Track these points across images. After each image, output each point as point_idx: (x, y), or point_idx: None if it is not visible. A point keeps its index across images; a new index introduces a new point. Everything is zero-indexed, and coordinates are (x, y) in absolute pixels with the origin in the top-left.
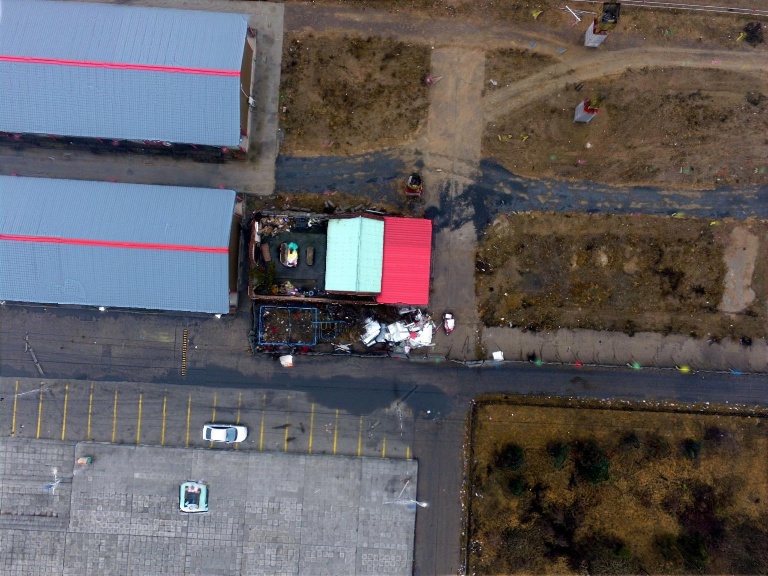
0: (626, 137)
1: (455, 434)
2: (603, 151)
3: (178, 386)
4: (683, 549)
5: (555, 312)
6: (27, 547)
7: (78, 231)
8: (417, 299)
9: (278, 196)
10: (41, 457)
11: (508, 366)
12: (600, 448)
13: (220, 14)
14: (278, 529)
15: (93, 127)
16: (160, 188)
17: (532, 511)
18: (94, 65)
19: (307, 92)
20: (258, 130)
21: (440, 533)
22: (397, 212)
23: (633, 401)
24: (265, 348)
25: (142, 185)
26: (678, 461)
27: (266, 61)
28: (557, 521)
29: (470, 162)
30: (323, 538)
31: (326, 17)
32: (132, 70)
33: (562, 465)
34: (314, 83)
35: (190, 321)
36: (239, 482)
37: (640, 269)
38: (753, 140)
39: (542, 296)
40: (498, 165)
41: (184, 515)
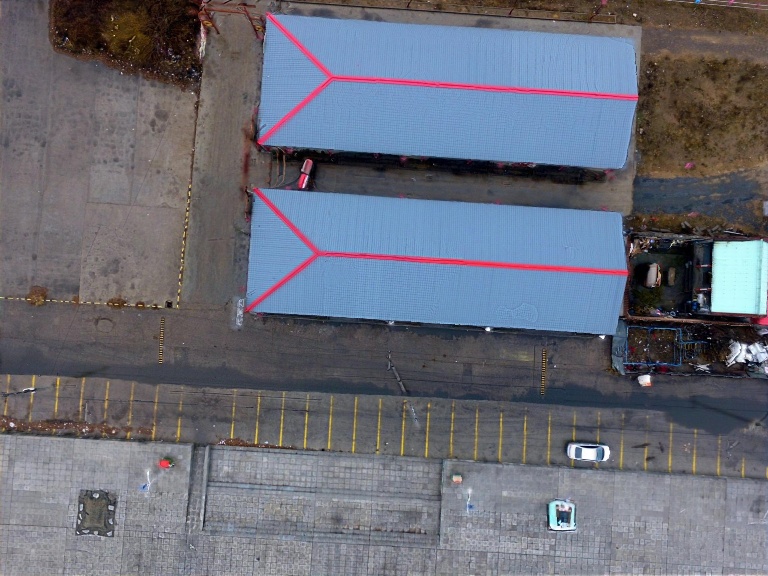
0: None
1: None
2: None
3: (537, 405)
4: None
5: None
6: (399, 564)
7: (478, 253)
8: None
9: (635, 217)
10: (407, 474)
11: None
12: None
13: None
14: (645, 548)
15: (482, 150)
16: (547, 210)
17: None
18: (498, 90)
19: (663, 114)
20: None
21: None
22: (754, 233)
23: None
24: (626, 368)
25: (530, 207)
26: None
27: None
28: None
29: None
30: (689, 558)
31: (682, 40)
32: (536, 95)
33: None
34: (670, 105)
35: (549, 340)
36: (605, 501)
37: None
38: None
39: None
40: None
41: (552, 533)
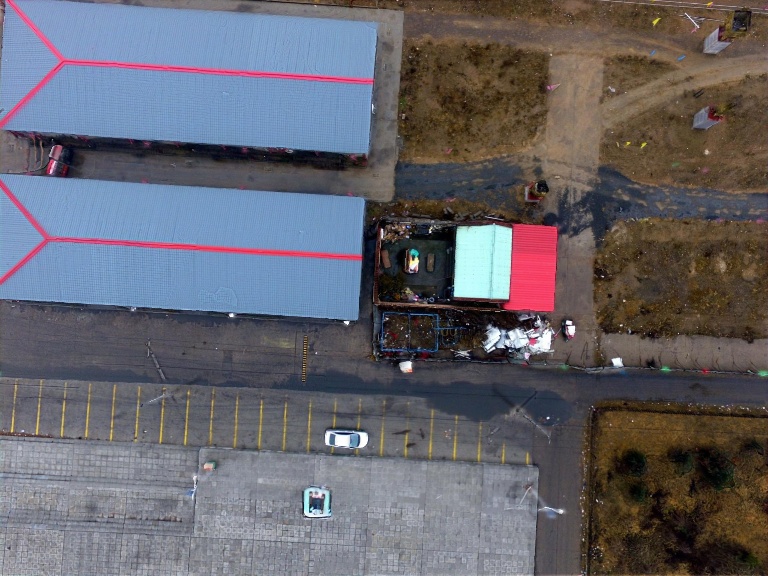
0: (744, 144)
1: (574, 440)
2: (721, 158)
3: (298, 392)
4: None
5: (674, 319)
6: (152, 552)
7: (212, 238)
8: (543, 306)
9: (397, 203)
10: (164, 462)
11: (627, 372)
12: None
13: (348, 22)
14: (400, 535)
15: (224, 135)
16: (290, 195)
17: (653, 517)
18: (230, 73)
19: (426, 99)
20: (378, 137)
21: (560, 539)
22: (516, 219)
23: (752, 408)
24: (386, 354)
25: (272, 192)
26: None
27: (385, 68)
28: (678, 527)
29: (588, 169)
30: (445, 544)
31: (445, 24)
32: (268, 78)
33: (682, 471)
34: (433, 90)
35: (310, 327)
36: (361, 488)
37: (759, 276)
38: None
39: (661, 303)
40: (616, 172)
41: (307, 520)
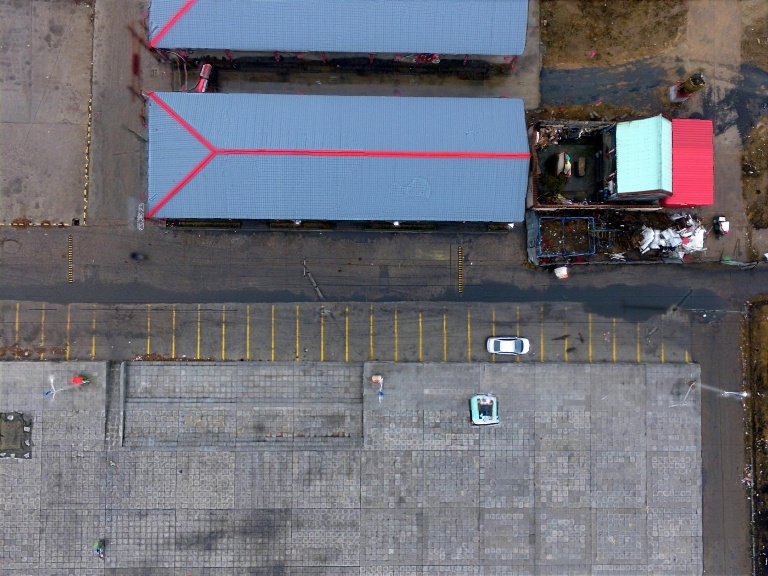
0: None
1: (732, 336)
2: None
3: (456, 303)
4: None
5: None
6: (324, 467)
7: (379, 144)
8: (703, 199)
9: (544, 110)
10: (328, 379)
11: None
12: None
13: None
14: (568, 437)
15: (380, 42)
16: (449, 100)
17: None
18: None
19: (566, 5)
20: None
21: (724, 434)
22: None
23: None
24: (542, 260)
25: (431, 98)
26: None
27: None
28: None
29: (731, 67)
30: (613, 444)
31: None
32: None
33: None
34: None
35: (464, 238)
36: (527, 393)
37: None
38: None
39: None
40: (758, 68)
41: (475, 428)
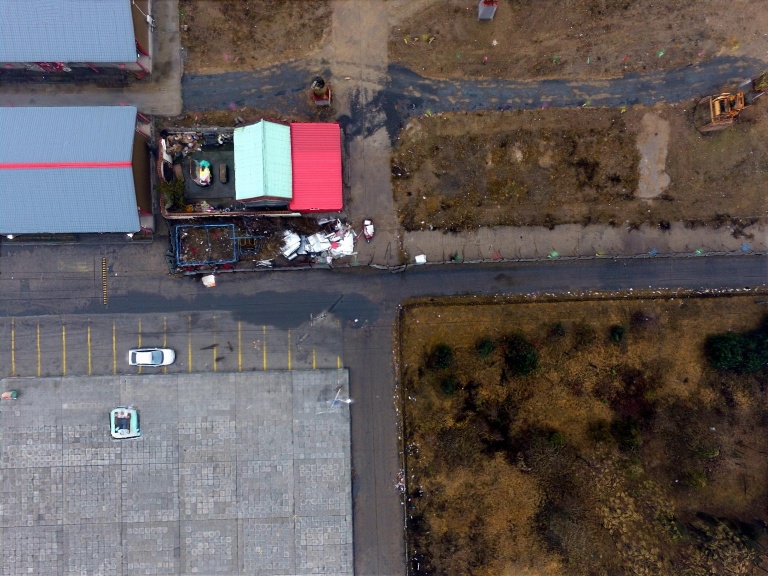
0: (532, 32)
1: (384, 340)
2: (510, 47)
3: (101, 315)
4: (616, 433)
5: (474, 211)
6: None
7: None
8: (331, 204)
9: (187, 116)
10: None
11: (432, 269)
12: (528, 341)
13: None
14: (213, 448)
15: None
16: (59, 109)
17: (466, 409)
18: None
19: (208, 9)
20: (161, 50)
21: (376, 439)
22: None
23: (558, 293)
24: (186, 269)
25: (40, 108)
26: (606, 348)
27: None
28: (491, 417)
29: (378, 68)
30: (259, 453)
31: None
32: None
33: (492, 362)
34: None
35: (108, 249)
36: (170, 405)
37: (555, 162)
38: (657, 25)
39: (460, 197)
40: (406, 69)
41: (116, 442)
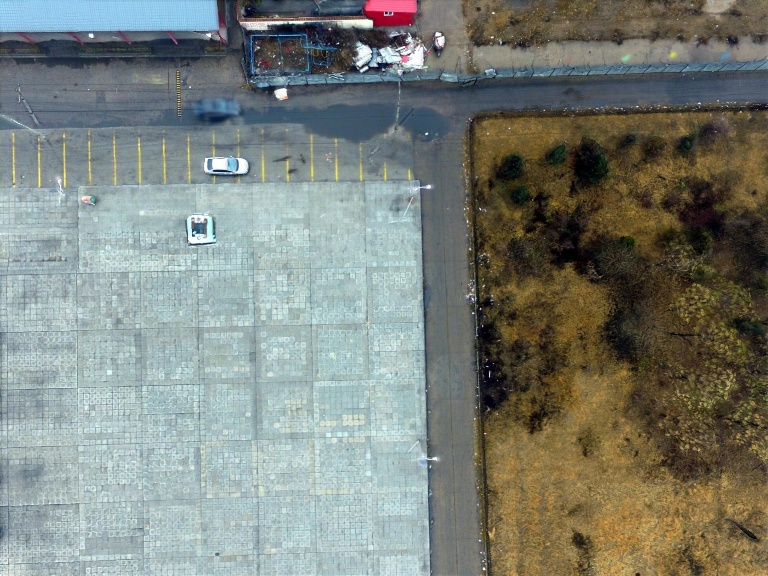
0: None
1: (454, 153)
2: None
3: (175, 127)
4: (686, 242)
5: (543, 27)
6: (39, 291)
7: None
8: (406, 7)
9: None
10: (45, 205)
11: (501, 83)
12: None
13: None
14: (287, 255)
15: None
16: None
17: (536, 220)
18: None
19: None
20: None
21: (447, 250)
22: None
23: (626, 107)
24: (259, 81)
25: None
26: (675, 160)
27: None
28: (561, 228)
29: None
30: (332, 261)
31: None
32: None
33: (562, 173)
34: None
35: (182, 62)
36: (244, 212)
37: None
38: None
39: (529, 12)
40: None
41: (193, 248)
